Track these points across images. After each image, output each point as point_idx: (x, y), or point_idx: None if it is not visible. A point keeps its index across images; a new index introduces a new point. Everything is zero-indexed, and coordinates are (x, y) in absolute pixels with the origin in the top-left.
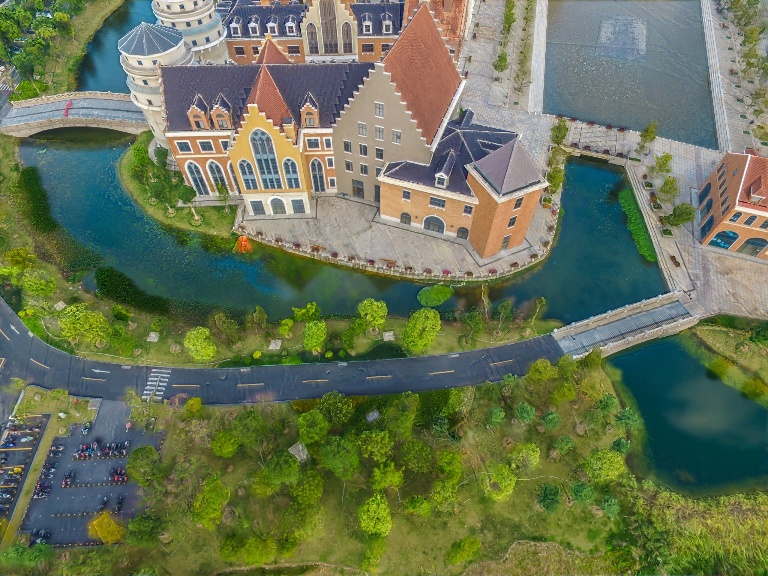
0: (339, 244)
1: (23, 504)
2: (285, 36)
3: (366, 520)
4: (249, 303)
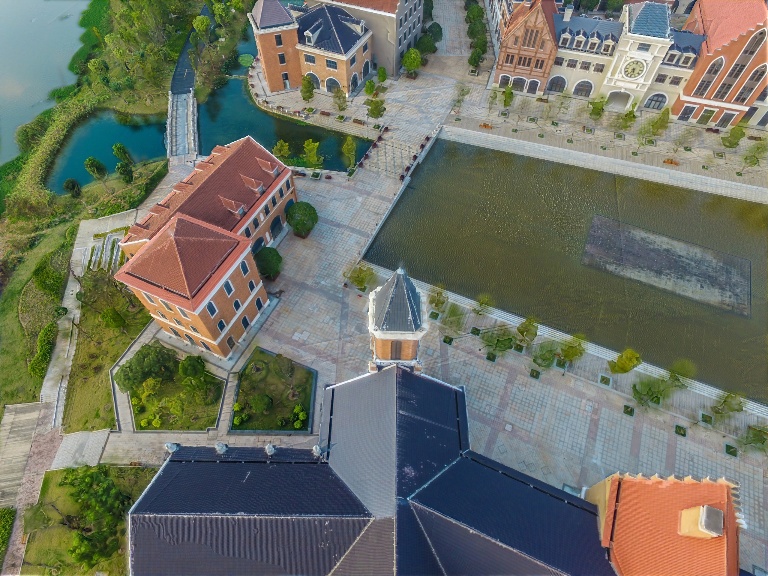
0: None
1: None
2: None
3: None
4: None
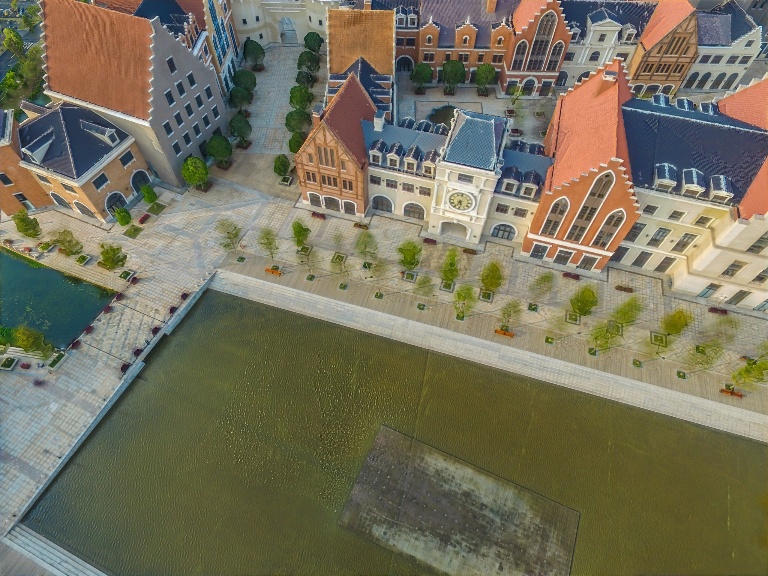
0: None
1: None
2: None
3: None
4: None
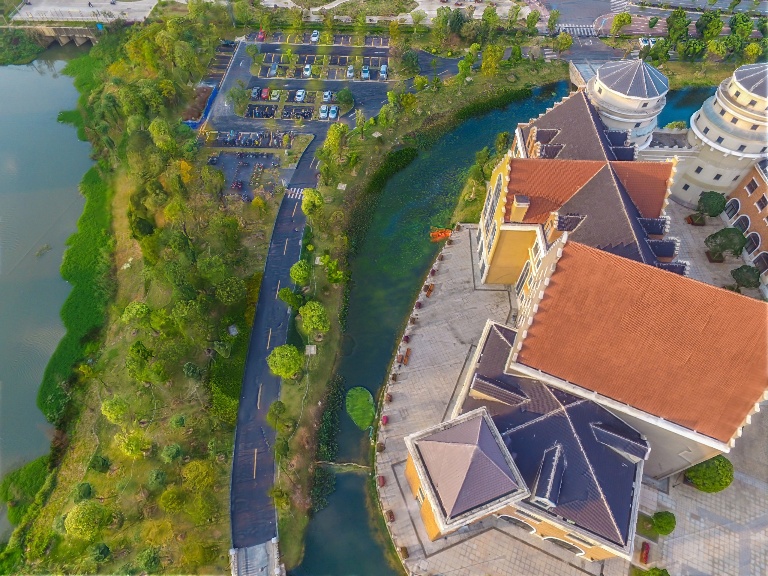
0: (436, 310)
1: (236, 150)
2: None
3: (134, 303)
4: (370, 242)
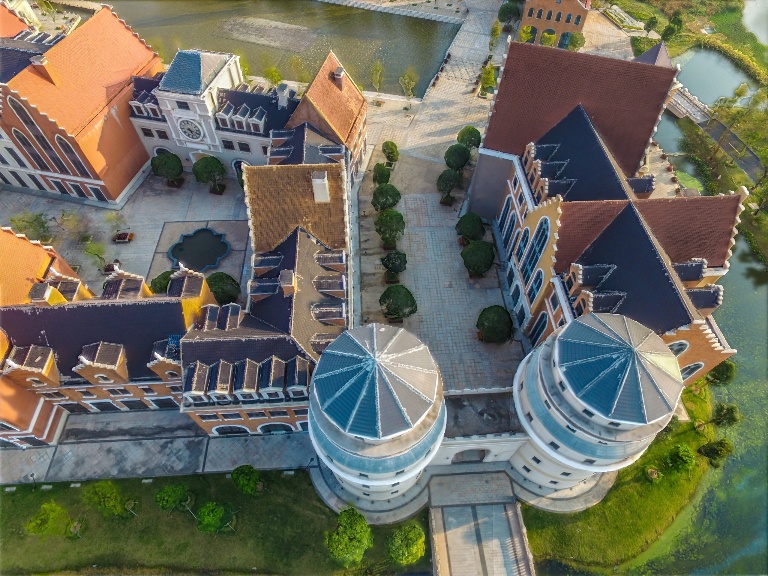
0: None
1: None
2: (346, 277)
3: None
4: None
